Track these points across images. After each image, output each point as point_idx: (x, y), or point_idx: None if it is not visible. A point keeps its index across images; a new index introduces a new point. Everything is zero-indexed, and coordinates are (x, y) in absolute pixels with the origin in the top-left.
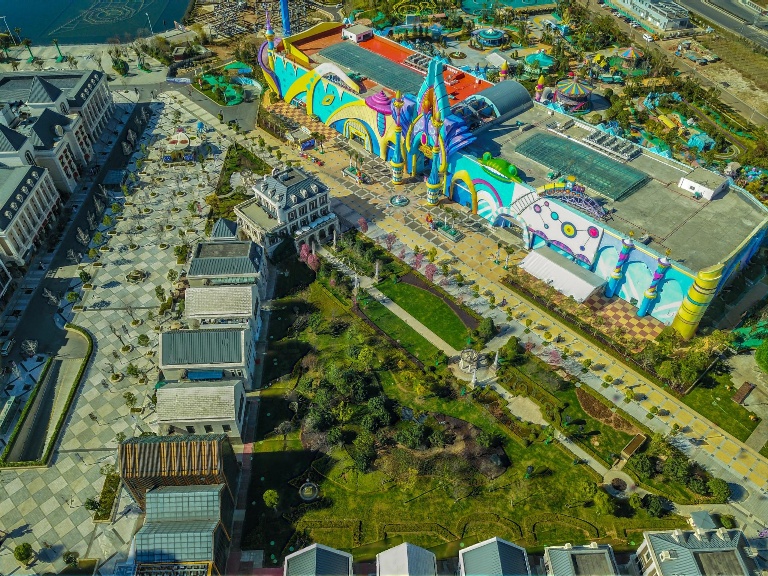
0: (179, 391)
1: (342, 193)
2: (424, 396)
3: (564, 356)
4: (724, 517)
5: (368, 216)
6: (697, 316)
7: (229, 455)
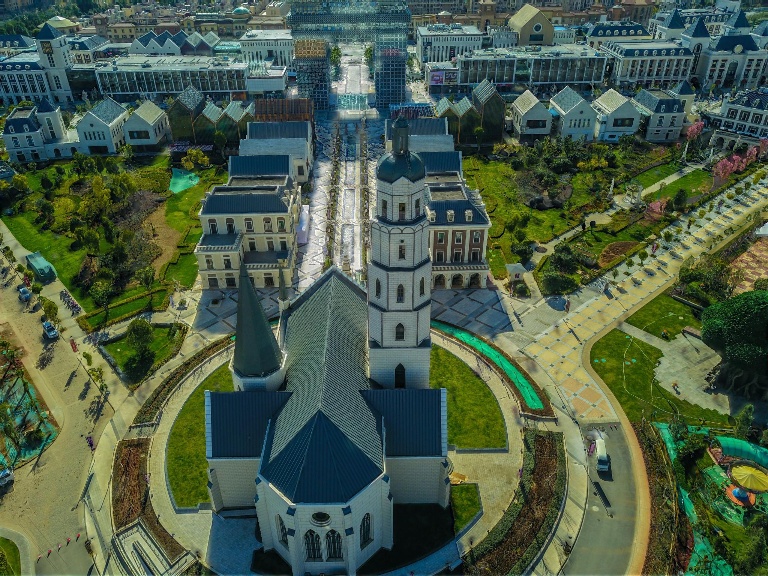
0: None
1: None
2: (586, 183)
3: (677, 238)
4: None
5: None
6: None
7: (499, 116)
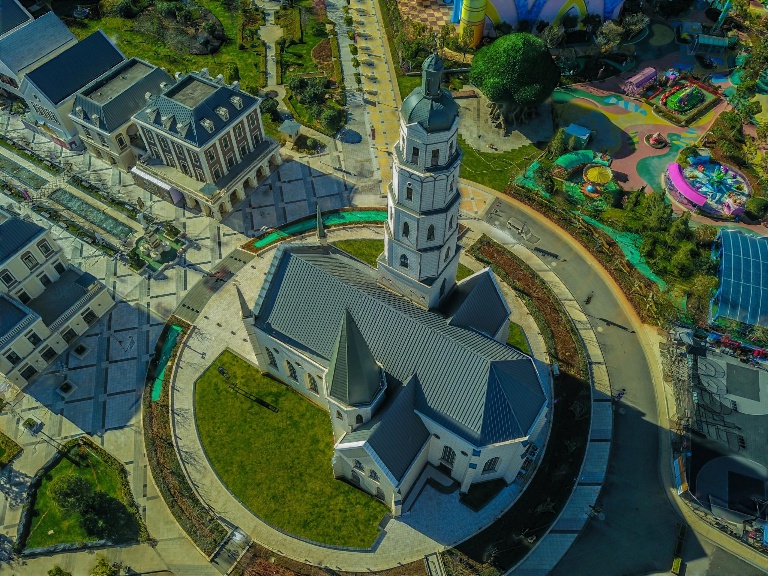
0: None
1: None
2: None
3: None
4: (313, 138)
5: None
6: (468, 12)
7: None
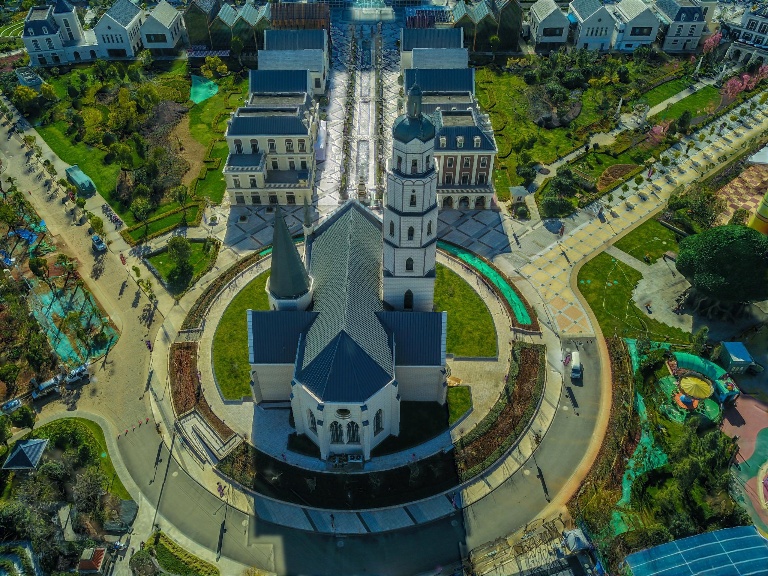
0: None
1: None
2: (596, 100)
3: (674, 162)
4: None
5: None
6: None
7: (515, 23)
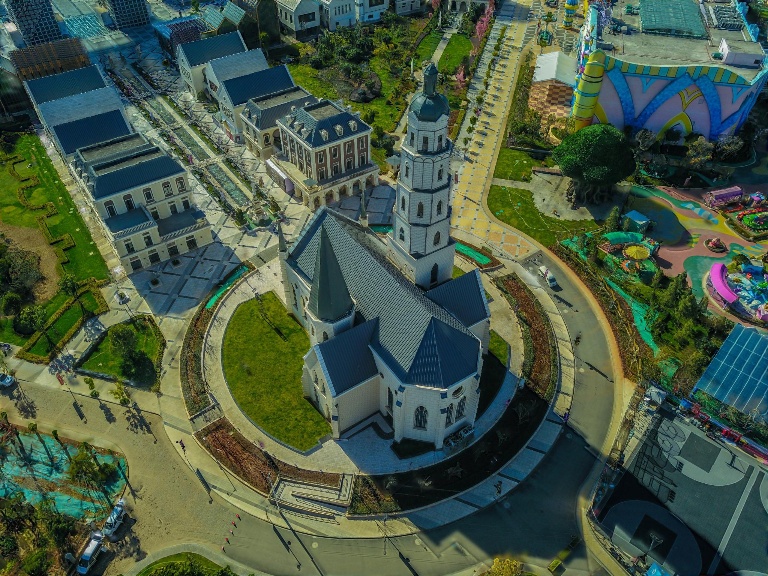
0: None
1: (524, 3)
2: (384, 68)
3: None
4: None
5: (516, 15)
6: (577, 108)
7: (272, 17)
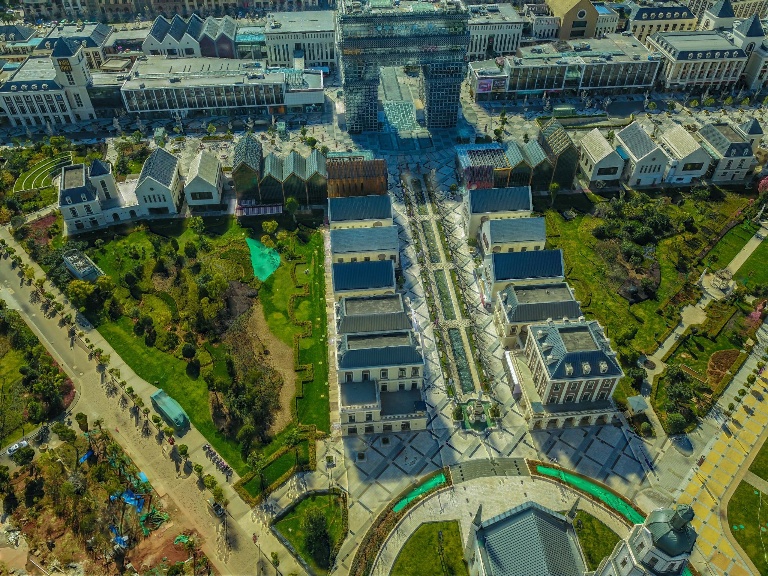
0: (600, 135)
1: None
2: (671, 259)
3: None
4: None
5: None
6: None
7: (572, 165)
